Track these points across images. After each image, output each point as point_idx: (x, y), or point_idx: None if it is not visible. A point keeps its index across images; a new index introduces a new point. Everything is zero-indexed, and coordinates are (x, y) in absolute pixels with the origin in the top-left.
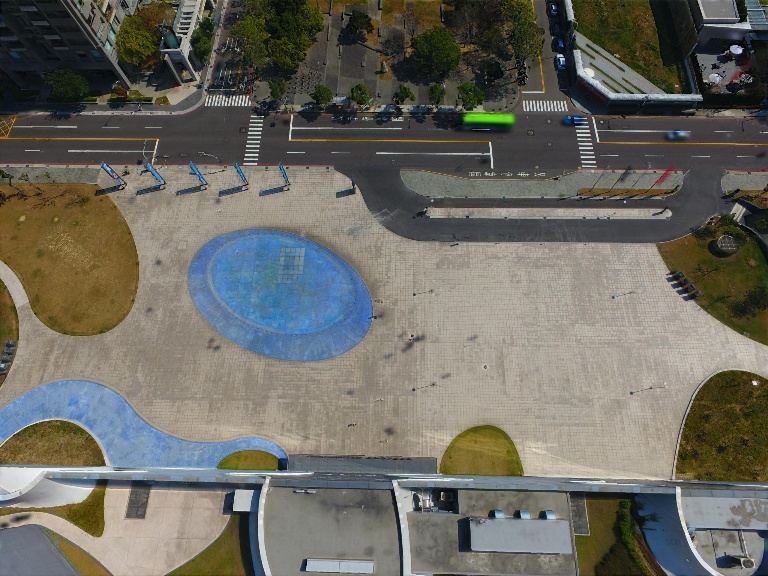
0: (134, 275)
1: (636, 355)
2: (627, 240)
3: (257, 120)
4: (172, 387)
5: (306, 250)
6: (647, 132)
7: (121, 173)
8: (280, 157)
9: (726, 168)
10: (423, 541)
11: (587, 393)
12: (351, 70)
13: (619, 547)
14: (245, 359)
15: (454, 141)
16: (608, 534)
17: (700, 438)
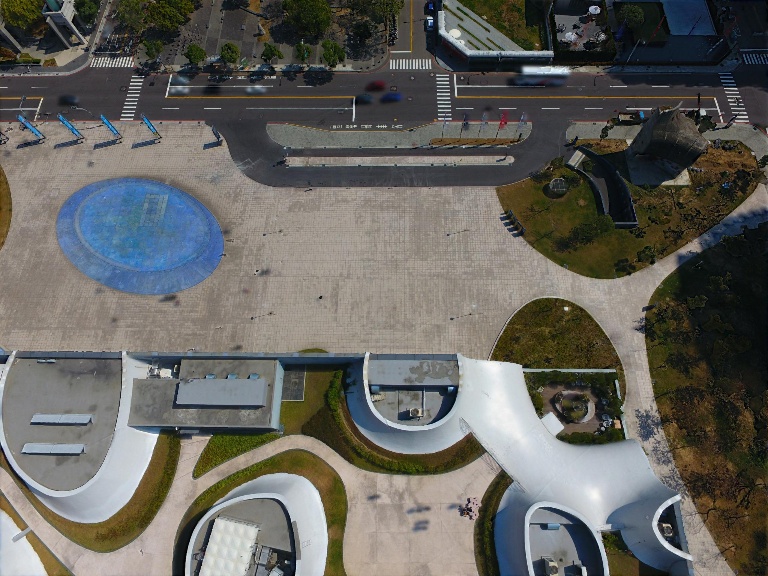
0: (6, 220)
1: (461, 285)
2: (469, 184)
3: (138, 80)
4: (30, 319)
5: (169, 196)
6: (504, 87)
7: (5, 129)
8: (155, 113)
9: (573, 119)
10: (143, 400)
11: (411, 319)
12: (231, 33)
13: (324, 409)
14: (100, 293)
15: (321, 97)
16: (319, 399)
17: (508, 357)
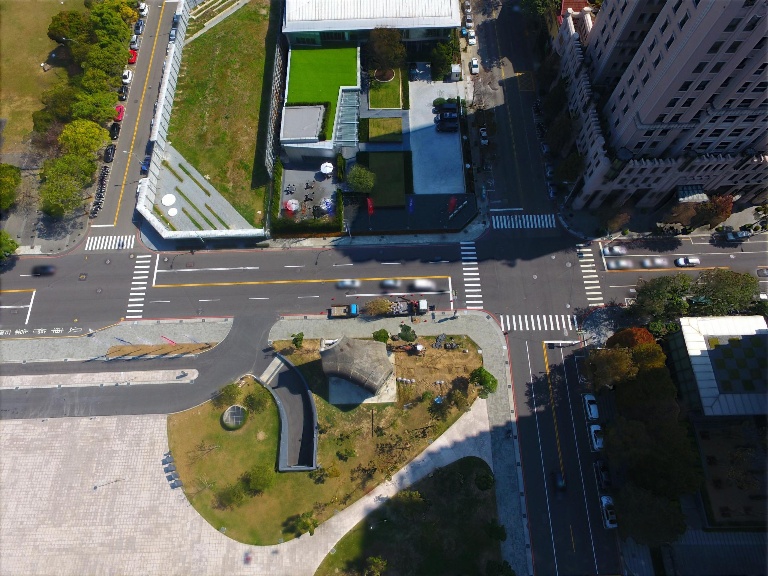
0: None
1: (92, 563)
2: (138, 411)
3: None
4: None
5: None
6: (211, 270)
7: None
8: None
9: (282, 312)
10: None
11: None
12: None
13: None
14: None
15: None
16: None
17: None
